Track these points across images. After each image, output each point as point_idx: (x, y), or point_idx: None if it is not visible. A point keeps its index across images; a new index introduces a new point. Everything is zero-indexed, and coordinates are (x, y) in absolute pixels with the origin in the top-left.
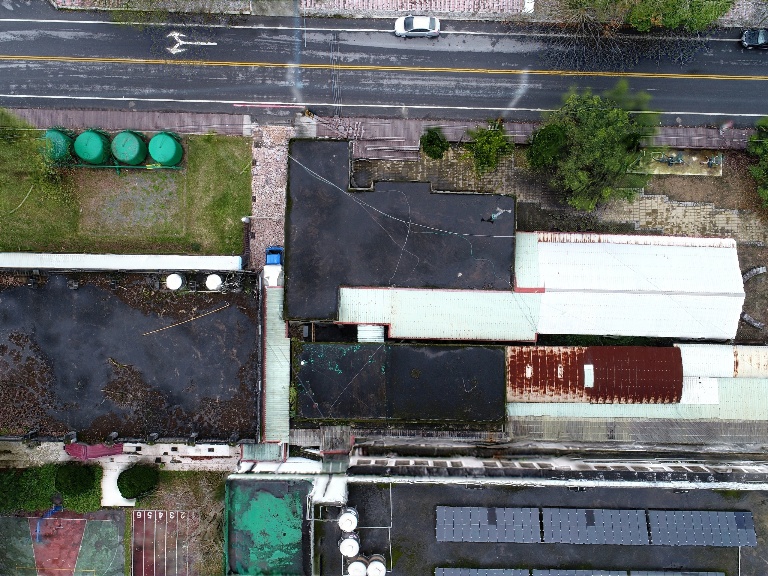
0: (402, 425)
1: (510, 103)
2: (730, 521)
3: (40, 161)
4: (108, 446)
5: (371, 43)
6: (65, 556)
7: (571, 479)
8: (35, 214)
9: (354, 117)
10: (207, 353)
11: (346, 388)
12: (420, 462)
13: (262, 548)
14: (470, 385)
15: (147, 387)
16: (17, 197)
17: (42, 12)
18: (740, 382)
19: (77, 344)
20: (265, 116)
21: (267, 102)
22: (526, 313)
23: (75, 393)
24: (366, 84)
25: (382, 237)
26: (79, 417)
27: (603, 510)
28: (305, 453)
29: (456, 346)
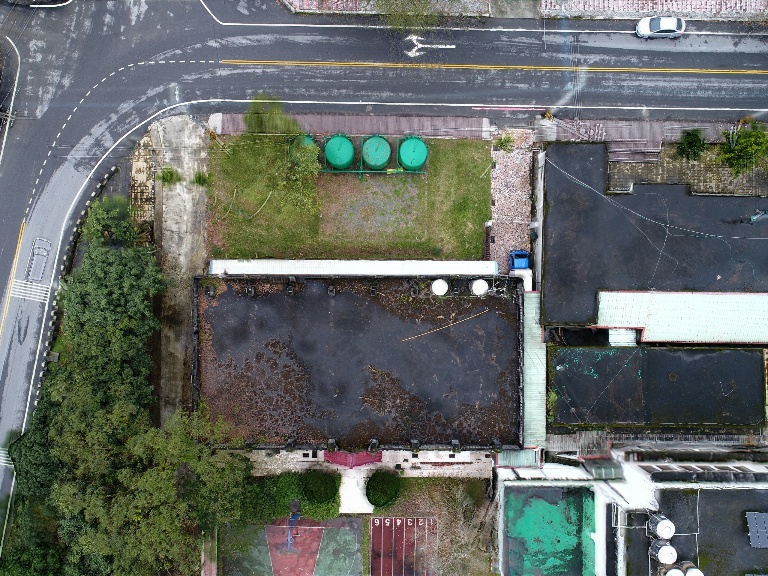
0: (659, 429)
1: (752, 104)
2: None
3: (279, 166)
4: (372, 454)
5: (612, 44)
6: (303, 564)
7: None
8: (274, 220)
9: (594, 119)
10: (466, 359)
11: (603, 393)
12: (705, 467)
13: (536, 555)
14: (728, 388)
15: (405, 394)
16: (255, 203)
17: (278, 16)
18: None
19: (334, 351)
20: (504, 119)
21: (506, 105)
22: None
23: (333, 400)
24: (607, 86)
25: (640, 240)
26: (337, 425)
27: None
28: (559, 459)
29: (713, 349)
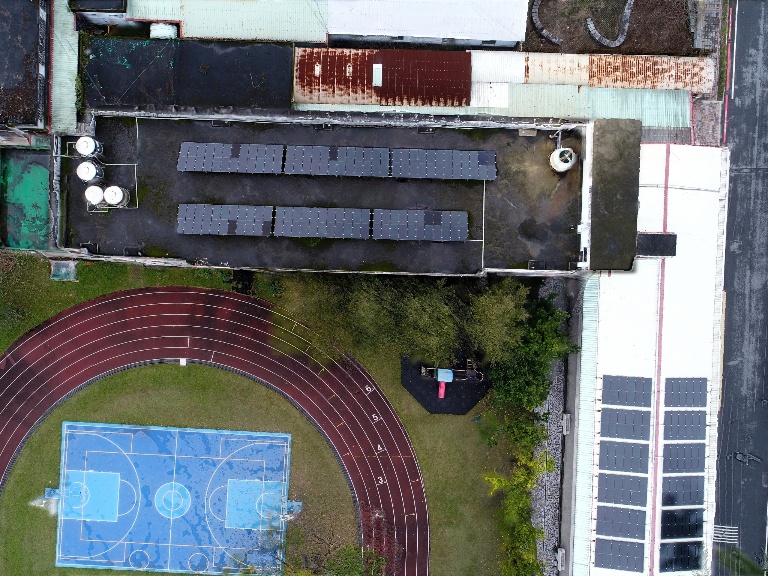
0: None
1: None
2: (472, 158)
3: None
4: None
5: None
6: None
7: (317, 117)
8: None
9: None
10: None
11: (134, 82)
12: None
13: (34, 221)
14: (258, 81)
15: None
16: None
17: None
18: (531, 87)
19: None
20: None
21: None
22: (315, 10)
23: None
24: None
25: None
26: None
27: (348, 148)
28: None
29: (244, 42)
